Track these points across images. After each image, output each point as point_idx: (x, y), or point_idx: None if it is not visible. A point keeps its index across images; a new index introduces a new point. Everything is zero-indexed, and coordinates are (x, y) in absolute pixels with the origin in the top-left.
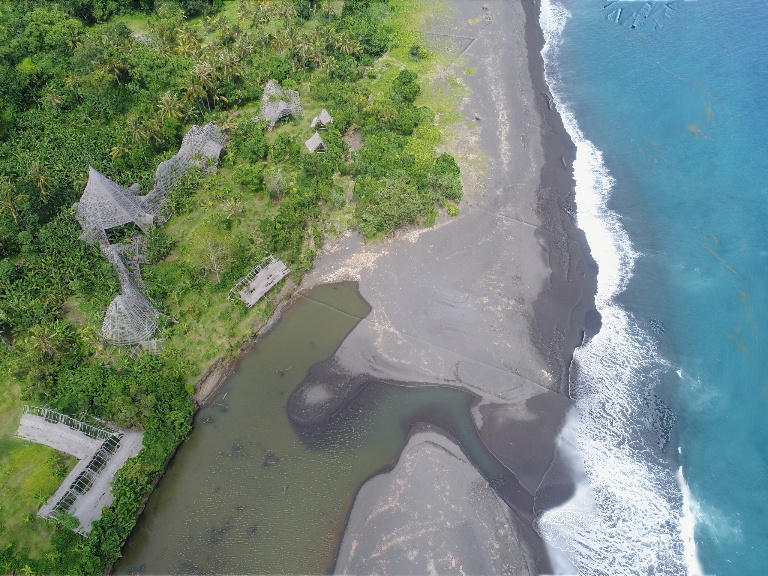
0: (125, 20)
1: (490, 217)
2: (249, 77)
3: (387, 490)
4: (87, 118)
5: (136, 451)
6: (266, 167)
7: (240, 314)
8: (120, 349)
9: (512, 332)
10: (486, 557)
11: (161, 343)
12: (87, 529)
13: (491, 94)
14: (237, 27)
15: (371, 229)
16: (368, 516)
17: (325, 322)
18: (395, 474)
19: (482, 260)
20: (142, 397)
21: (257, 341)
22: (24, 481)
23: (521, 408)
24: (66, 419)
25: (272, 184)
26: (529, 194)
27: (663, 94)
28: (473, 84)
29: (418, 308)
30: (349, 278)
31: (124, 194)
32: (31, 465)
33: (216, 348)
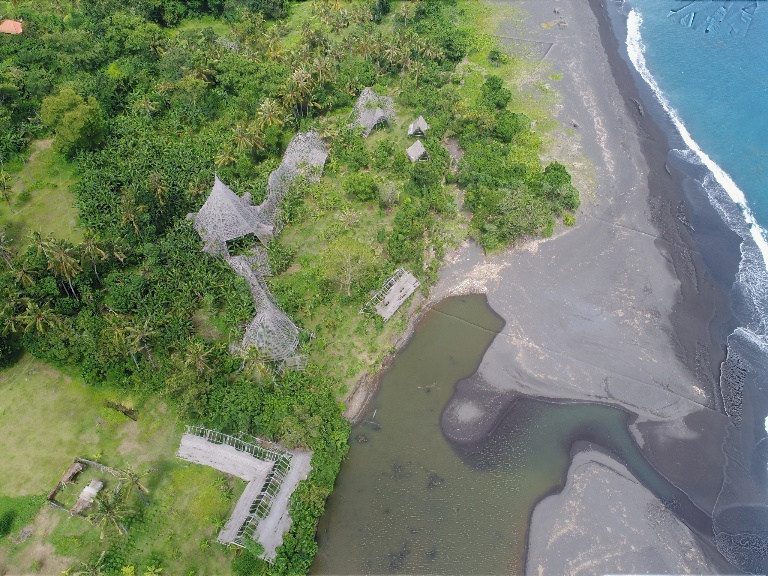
0: (193, 24)
1: (607, 227)
2: (338, 83)
3: (562, 512)
4: (180, 125)
5: (305, 473)
6: None
7: (376, 328)
8: (264, 365)
9: (655, 347)
10: None
11: (305, 359)
12: (271, 555)
13: (582, 100)
14: (319, 32)
15: (494, 240)
16: (548, 540)
17: (460, 336)
18: (566, 495)
19: (608, 272)
20: (306, 417)
21: (395, 356)
22: (191, 504)
23: (680, 426)
24: (231, 440)
25: (387, 194)
26: (641, 203)
27: (754, 100)
28: (562, 90)
29: (553, 322)
30: (476, 290)
31: (243, 204)
32: (195, 487)
33: (359, 364)
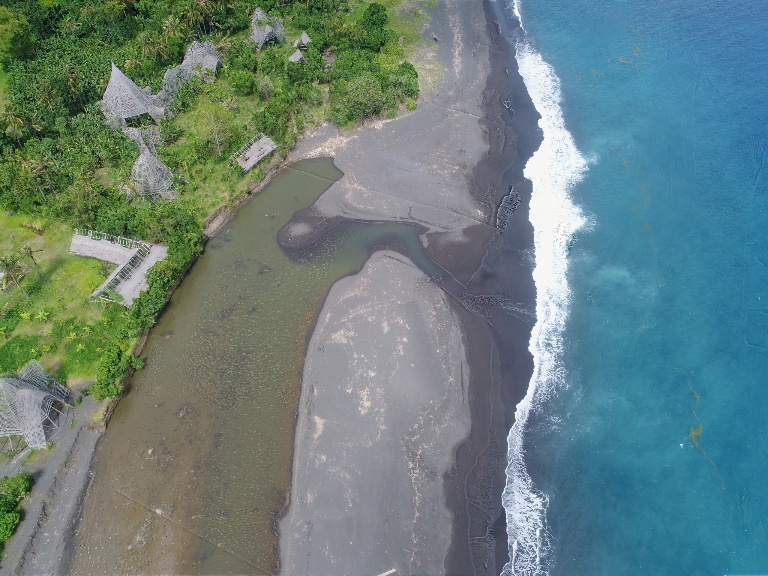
0: None
1: (442, 111)
2: (239, 8)
3: (354, 284)
4: (101, 42)
5: (162, 258)
6: None
7: (238, 177)
8: (144, 198)
9: (455, 186)
10: (426, 319)
11: (176, 194)
12: (129, 303)
13: (448, 21)
14: None
15: (343, 117)
16: (339, 299)
17: (306, 184)
18: (360, 275)
19: (434, 140)
20: (165, 220)
21: (252, 197)
22: (77, 282)
23: (459, 234)
24: (107, 236)
25: (261, 85)
26: (476, 94)
27: (596, 20)
28: (433, 14)
29: (381, 173)
30: (326, 155)
31: (139, 90)
32: (81, 272)
33: (220, 198)
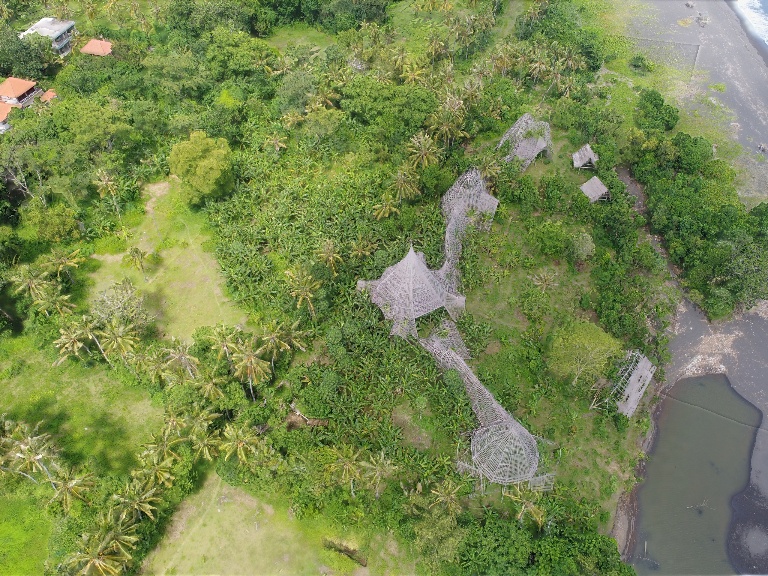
0: (285, 32)
1: None
2: (481, 105)
3: None
4: None
5: None
6: (543, 220)
7: (618, 429)
8: (505, 488)
9: None
10: None
11: (551, 478)
12: None
13: (757, 116)
14: (446, 43)
15: (724, 306)
16: None
17: (713, 433)
18: None
19: None
20: (597, 574)
21: (645, 463)
22: None
23: None
24: None
25: (585, 250)
26: None
27: None
28: (732, 104)
29: None
30: (712, 370)
31: None
32: None
33: (614, 480)
